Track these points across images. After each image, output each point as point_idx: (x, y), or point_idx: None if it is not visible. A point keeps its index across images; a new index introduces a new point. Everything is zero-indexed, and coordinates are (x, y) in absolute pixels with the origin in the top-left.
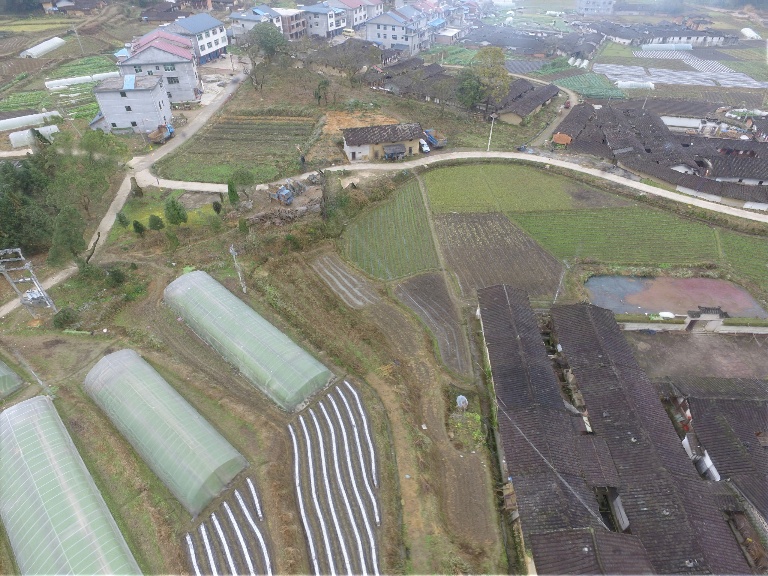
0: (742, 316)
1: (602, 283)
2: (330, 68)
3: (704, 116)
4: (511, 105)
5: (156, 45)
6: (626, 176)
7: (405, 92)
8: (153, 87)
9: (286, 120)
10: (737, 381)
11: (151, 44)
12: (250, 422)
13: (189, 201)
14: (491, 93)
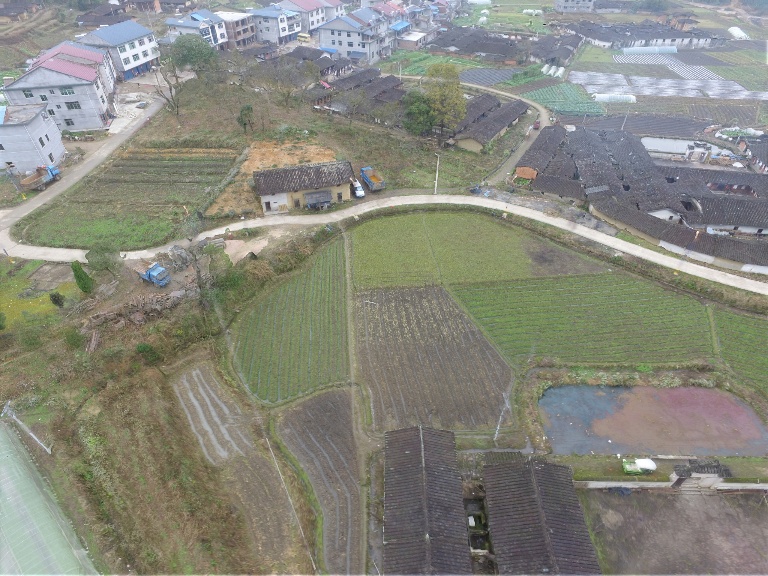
0: (747, 454)
1: (562, 399)
2: None
3: (691, 137)
4: (471, 128)
5: (48, 65)
6: (599, 228)
7: (352, 112)
8: (28, 121)
9: (203, 153)
10: None
11: (42, 64)
12: None
13: (46, 277)
14: (444, 118)
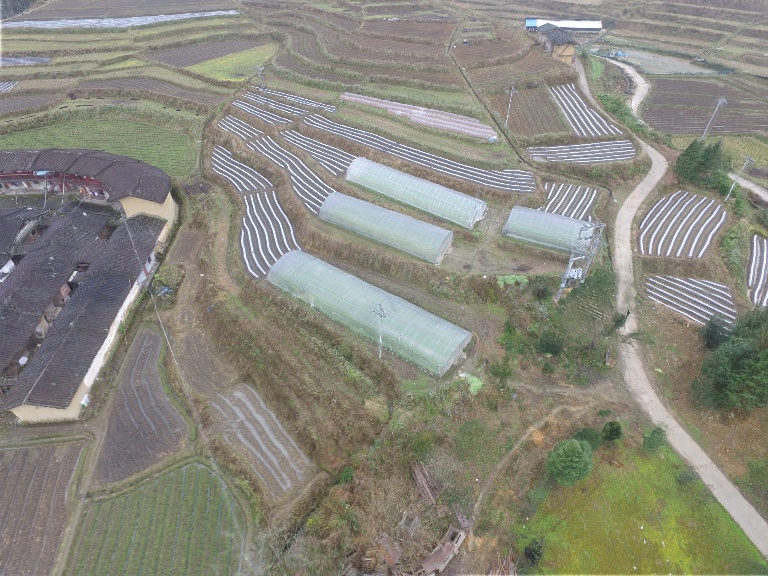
0: None
1: None
2: None
3: None
4: None
5: None
6: None
7: None
8: None
9: None
10: None
11: None
12: (323, 232)
13: None
14: None
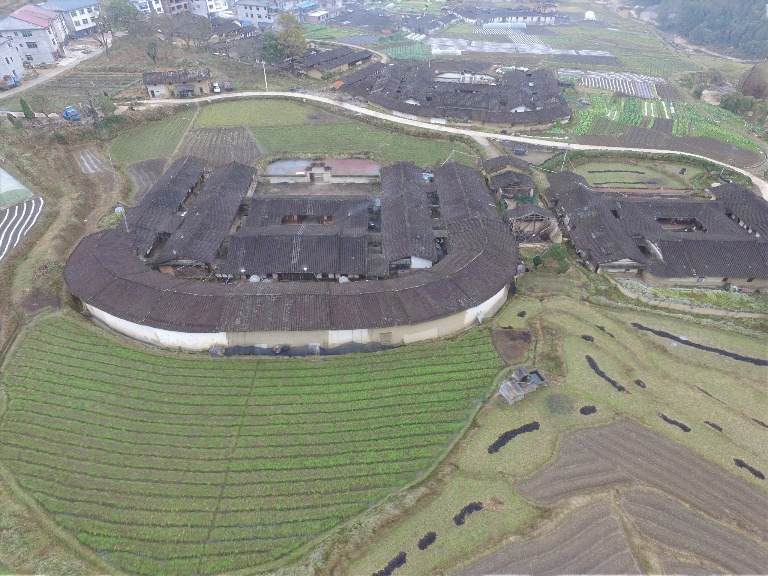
0: None
1: (283, 163)
2: None
3: (478, 72)
4: None
5: (13, 15)
6: (357, 105)
7: (241, 56)
8: None
9: (122, 75)
10: (299, 195)
11: None
12: None
13: (7, 123)
14: (288, 51)
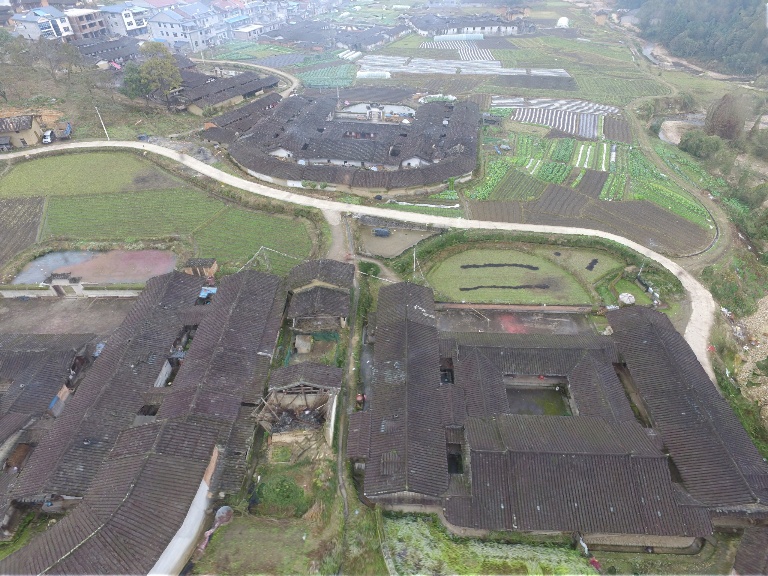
0: (140, 282)
1: (52, 257)
2: (74, 66)
3: (397, 102)
4: None
5: None
6: (205, 160)
7: None
8: None
9: None
10: None
11: None
12: None
13: None
14: None
